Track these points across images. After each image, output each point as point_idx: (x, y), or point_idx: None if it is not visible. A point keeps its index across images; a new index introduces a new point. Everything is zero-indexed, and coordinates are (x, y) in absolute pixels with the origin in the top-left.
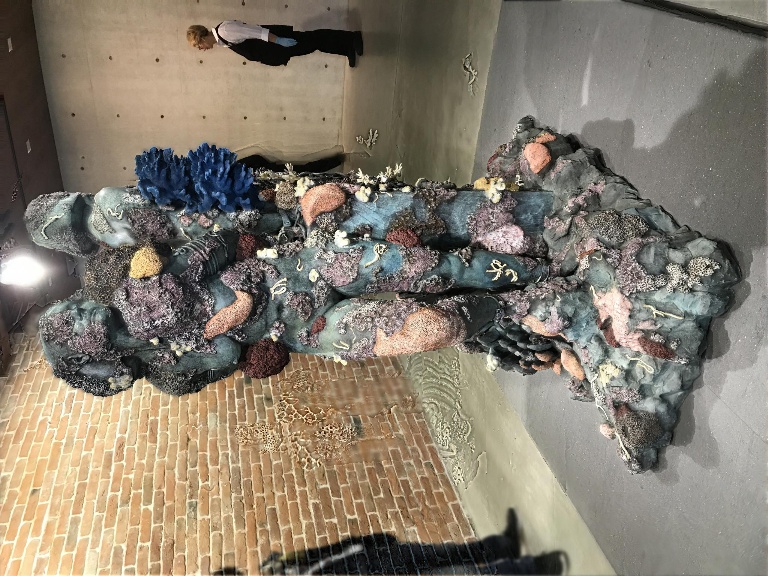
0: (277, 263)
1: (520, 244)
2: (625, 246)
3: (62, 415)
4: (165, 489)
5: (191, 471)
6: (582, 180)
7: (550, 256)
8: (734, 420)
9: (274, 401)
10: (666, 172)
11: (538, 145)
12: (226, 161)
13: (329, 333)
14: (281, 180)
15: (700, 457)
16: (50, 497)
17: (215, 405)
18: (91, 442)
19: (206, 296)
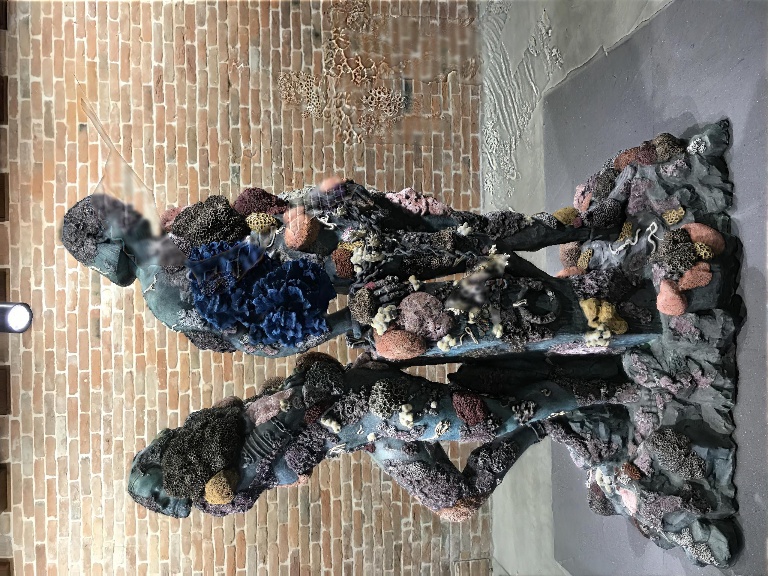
0: (339, 432)
1: (598, 351)
2: (671, 477)
3: (86, 12)
4: (209, 147)
5: (233, 131)
6: (696, 353)
7: (622, 362)
8: (661, 569)
9: (323, 39)
10: (764, 444)
11: (677, 303)
12: (298, 324)
13: (376, 460)
14: (361, 237)
15: (631, 537)
16: (98, 137)
17: (257, 34)
18: (126, 67)
19: (271, 482)
